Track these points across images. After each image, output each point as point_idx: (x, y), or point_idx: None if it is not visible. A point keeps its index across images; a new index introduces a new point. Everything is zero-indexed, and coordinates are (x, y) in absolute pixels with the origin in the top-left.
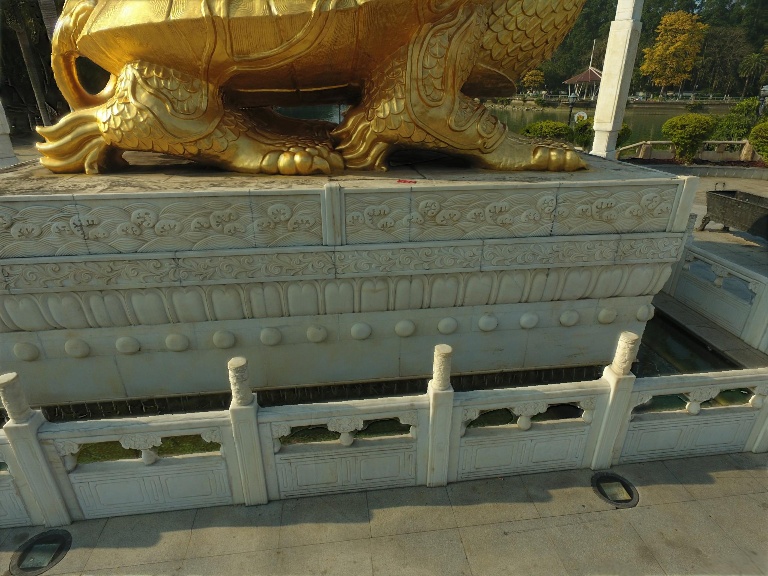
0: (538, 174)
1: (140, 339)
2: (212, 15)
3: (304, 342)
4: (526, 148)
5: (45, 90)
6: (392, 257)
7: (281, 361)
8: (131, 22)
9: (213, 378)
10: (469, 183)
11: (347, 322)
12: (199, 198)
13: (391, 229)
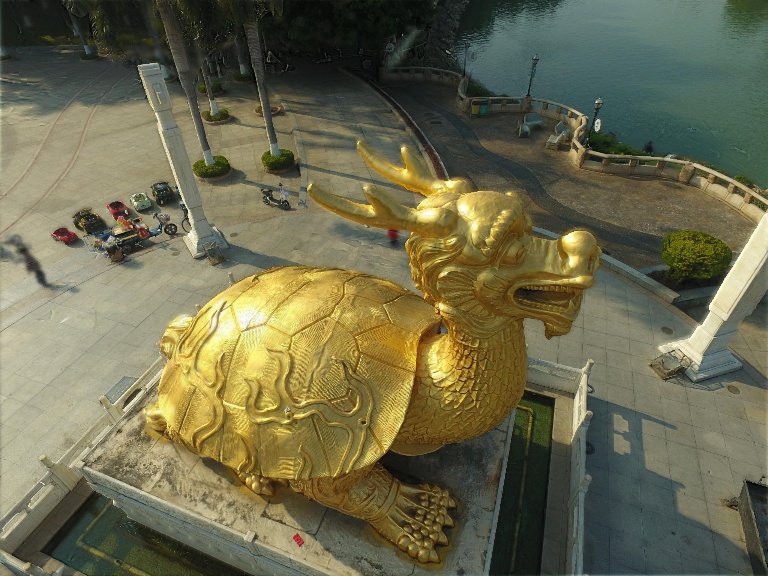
0: (392, 559)
1: (178, 530)
2: (195, 446)
3: (251, 565)
4: (397, 531)
5: (264, 62)
6: (284, 572)
7: (242, 564)
8: (167, 419)
9: (213, 553)
10: (328, 563)
11: (271, 571)
12: (189, 515)
13: (283, 562)
